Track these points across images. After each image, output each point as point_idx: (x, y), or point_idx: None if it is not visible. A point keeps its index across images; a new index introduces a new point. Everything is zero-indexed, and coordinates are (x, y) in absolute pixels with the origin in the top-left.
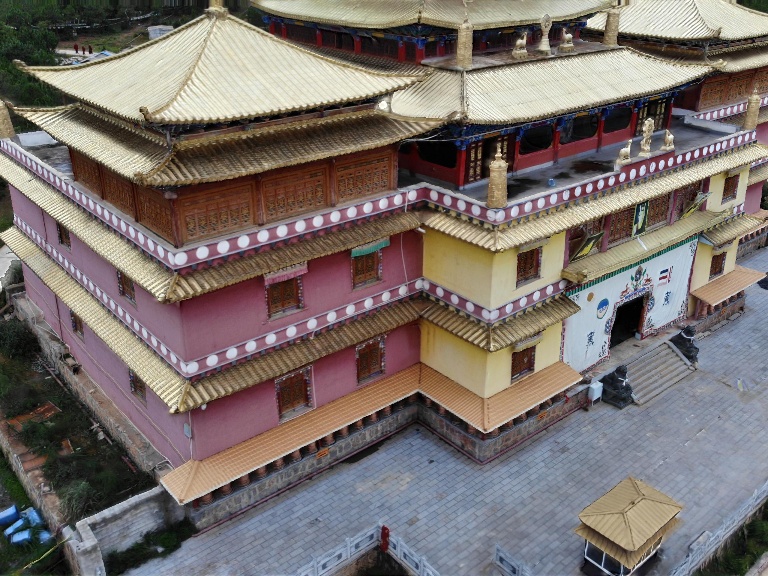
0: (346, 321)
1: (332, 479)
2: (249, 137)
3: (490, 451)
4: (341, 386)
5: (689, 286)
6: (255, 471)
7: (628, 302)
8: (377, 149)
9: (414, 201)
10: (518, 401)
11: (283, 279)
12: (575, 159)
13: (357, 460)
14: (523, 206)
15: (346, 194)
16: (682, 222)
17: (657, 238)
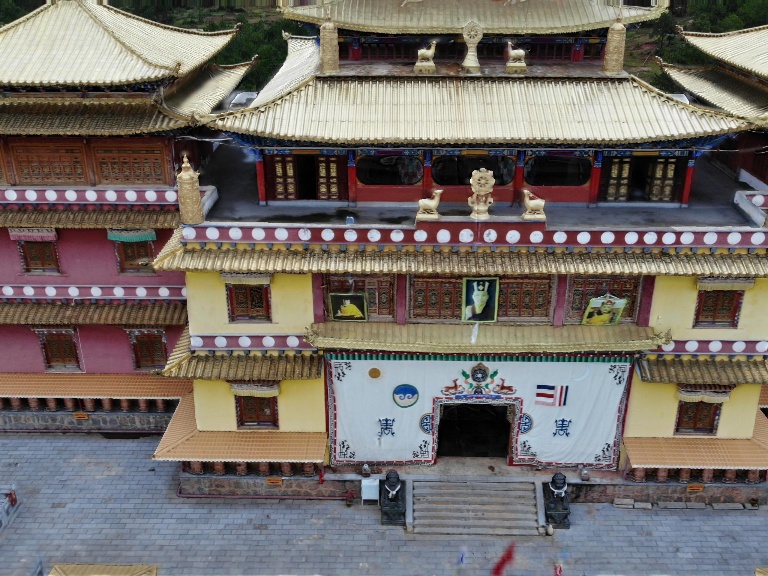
0: (114, 301)
1: (74, 442)
2: (5, 104)
3: (192, 487)
4: (115, 363)
5: (623, 427)
6: (9, 402)
7: (489, 408)
8: (143, 139)
9: None
10: (222, 448)
11: (30, 239)
12: (460, 207)
13: (112, 438)
14: (227, 231)
15: (111, 177)
16: (583, 329)
17: (511, 335)
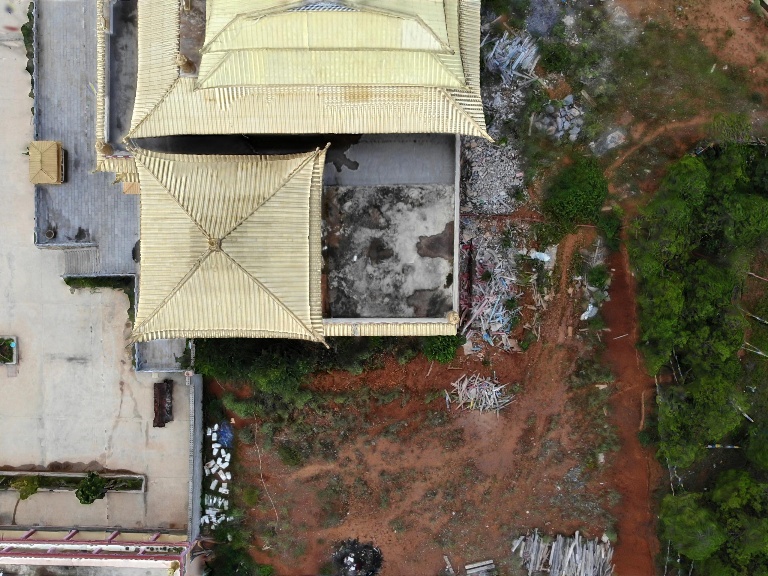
0: None
1: None
2: None
3: None
4: None
5: None
6: None
7: None
8: None
9: None
10: None
11: None
12: None
13: None
14: None
15: None
16: None
17: None
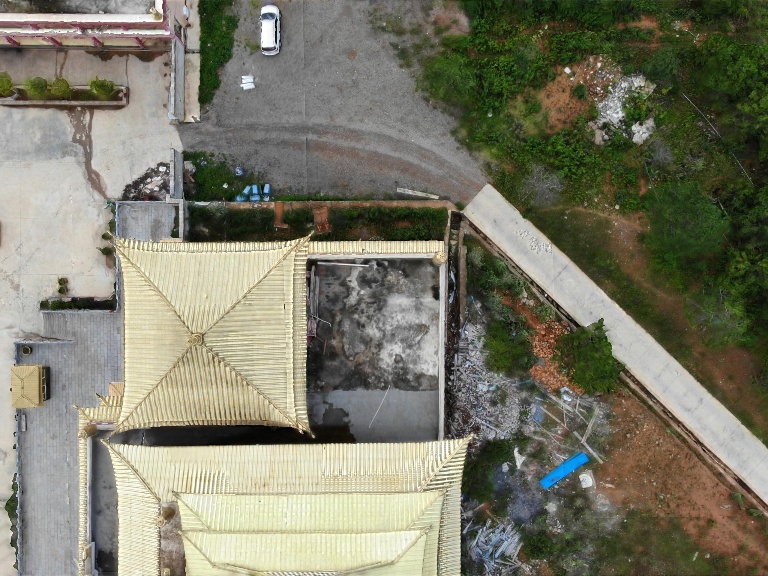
0: None
1: None
2: None
3: None
4: None
5: None
6: None
7: None
8: None
9: None
10: None
11: None
12: None
13: None
14: None
15: None
16: None
17: None
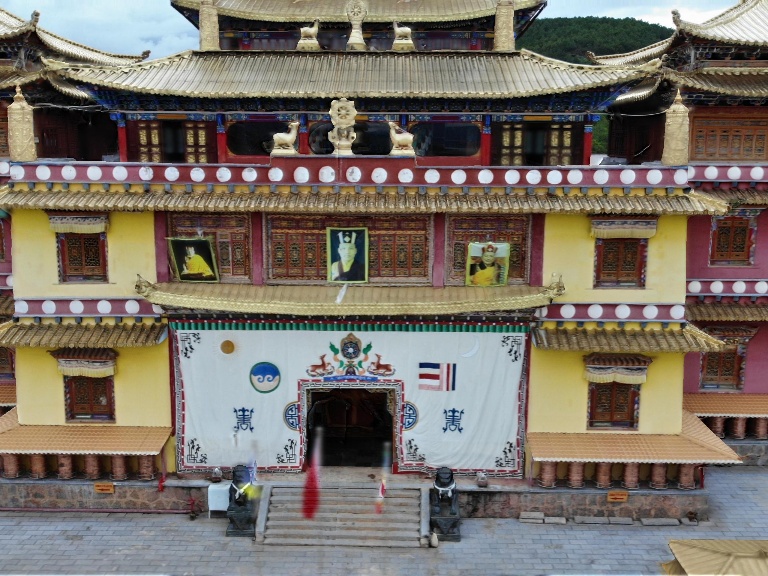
0: None
1: None
2: None
3: (5, 497)
4: None
5: (526, 420)
6: None
7: (368, 400)
8: None
9: None
10: (41, 440)
11: None
12: None
13: None
14: (59, 170)
15: None
16: (467, 290)
17: (384, 296)
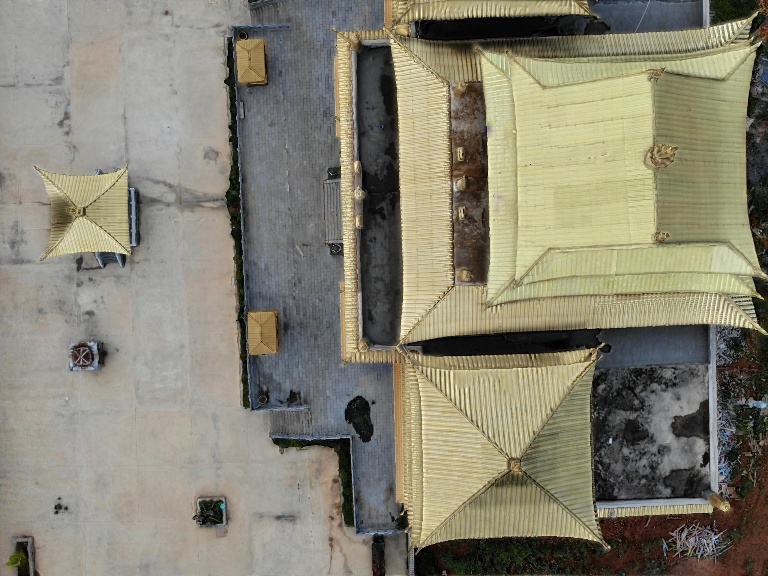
0: None
1: (382, 1)
2: None
3: None
4: None
5: None
6: None
7: None
8: None
9: (410, 31)
10: None
11: None
12: None
13: None
14: None
15: None
16: None
17: None
